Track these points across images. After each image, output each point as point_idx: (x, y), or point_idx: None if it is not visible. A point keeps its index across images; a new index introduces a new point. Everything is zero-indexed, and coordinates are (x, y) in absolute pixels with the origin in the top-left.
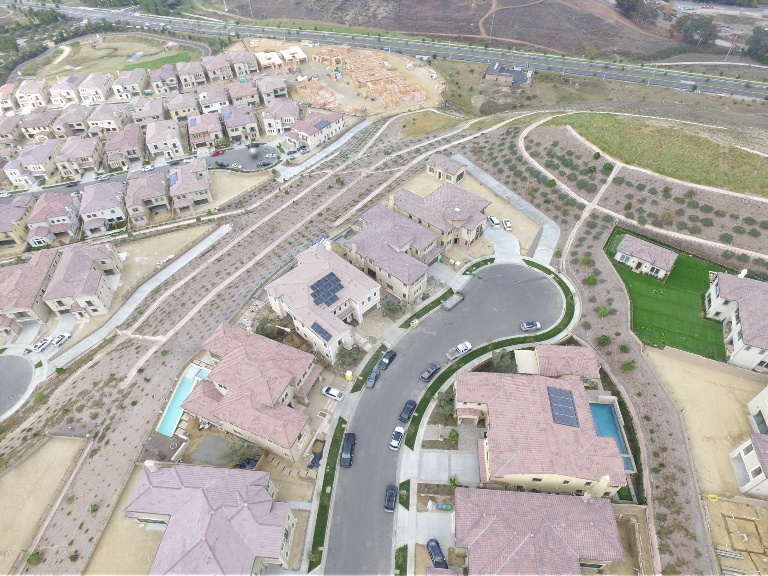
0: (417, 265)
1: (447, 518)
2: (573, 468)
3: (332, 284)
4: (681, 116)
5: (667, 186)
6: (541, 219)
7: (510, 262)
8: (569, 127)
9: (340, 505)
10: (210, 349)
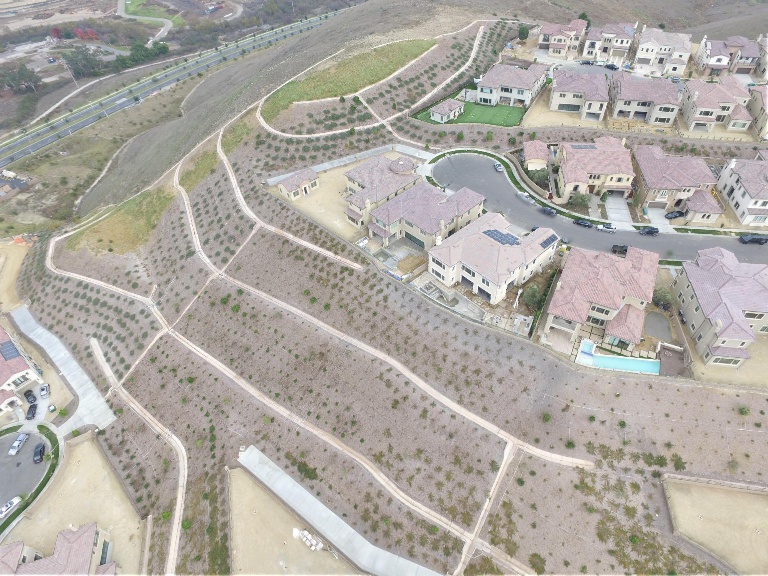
0: (465, 191)
1: (650, 211)
2: (622, 148)
3: (495, 234)
4: (315, 60)
5: (388, 84)
6: (383, 150)
7: (431, 170)
8: (295, 103)
9: (663, 256)
10: (585, 315)
